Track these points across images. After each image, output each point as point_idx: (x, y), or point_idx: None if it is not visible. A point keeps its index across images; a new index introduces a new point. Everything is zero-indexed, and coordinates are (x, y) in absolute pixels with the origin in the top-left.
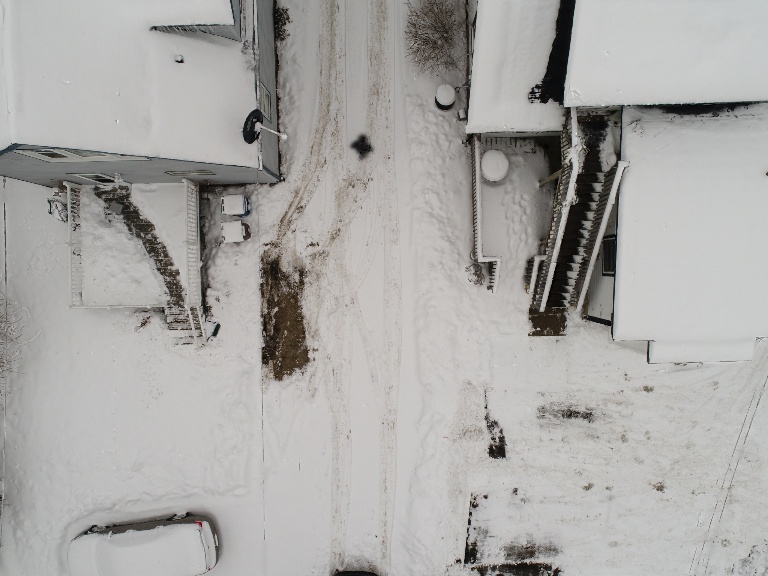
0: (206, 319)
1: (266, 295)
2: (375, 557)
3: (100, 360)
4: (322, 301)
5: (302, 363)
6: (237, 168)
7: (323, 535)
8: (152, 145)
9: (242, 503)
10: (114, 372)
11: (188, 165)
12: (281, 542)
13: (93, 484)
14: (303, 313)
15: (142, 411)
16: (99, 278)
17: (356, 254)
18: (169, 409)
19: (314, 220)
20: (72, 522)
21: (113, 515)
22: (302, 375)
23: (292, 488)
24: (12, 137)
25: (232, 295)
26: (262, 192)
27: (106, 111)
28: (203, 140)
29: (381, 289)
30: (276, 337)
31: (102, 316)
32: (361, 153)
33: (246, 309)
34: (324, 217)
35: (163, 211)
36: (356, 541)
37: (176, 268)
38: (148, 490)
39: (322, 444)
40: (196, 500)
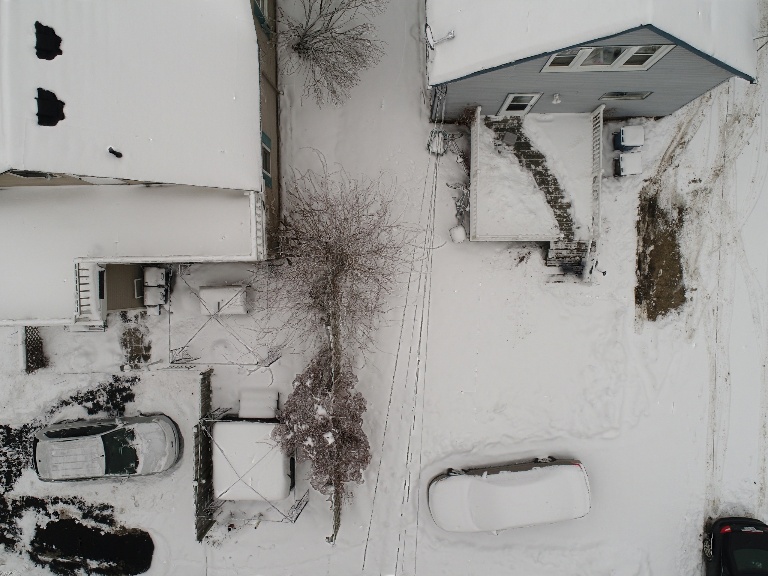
0: (589, 255)
1: (642, 233)
2: (752, 504)
3: (465, 298)
4: (704, 239)
5: (678, 303)
6: (693, 88)
7: (697, 481)
8: (713, 42)
9: (610, 447)
10: (479, 310)
11: (656, 81)
12: (651, 488)
13: (452, 426)
14: (681, 252)
15: (507, 351)
16: (493, 209)
17: (741, 191)
18: (536, 349)
19: (698, 156)
20: (427, 465)
21: (470, 458)
22: (678, 315)
23: (663, 432)
24: (649, 17)
25: (610, 232)
26: (648, 126)
27: (694, 1)
28: (736, 43)
29: (767, 227)
30: (650, 276)
31: (470, 253)
32: (748, 87)
33: (621, 247)
34: (708, 153)
35: (560, 141)
36: (733, 487)
37: (568, 201)
38: (510, 432)
39: (698, 387)
40: (560, 443)
